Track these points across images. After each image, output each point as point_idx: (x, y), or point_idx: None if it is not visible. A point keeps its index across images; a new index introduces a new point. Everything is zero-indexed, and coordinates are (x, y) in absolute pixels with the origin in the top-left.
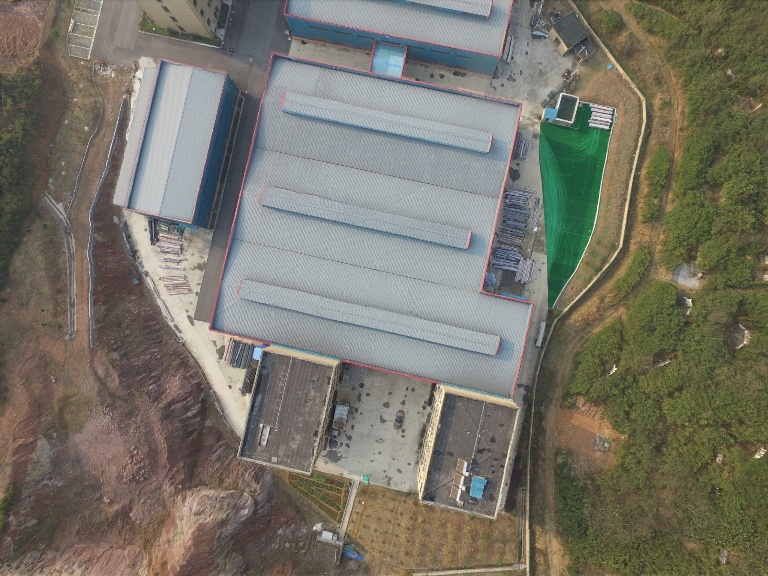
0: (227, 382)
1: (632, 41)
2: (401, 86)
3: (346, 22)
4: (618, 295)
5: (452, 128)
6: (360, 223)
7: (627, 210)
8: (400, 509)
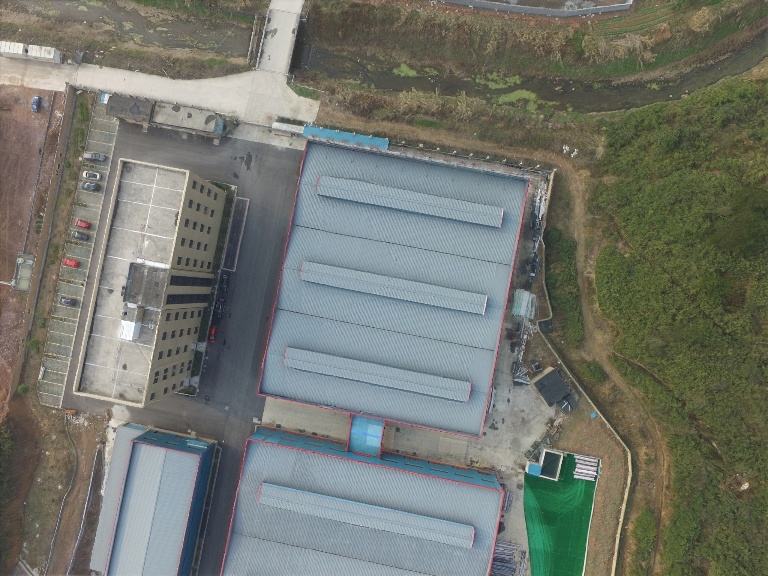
0: None
1: (615, 394)
2: (380, 470)
3: (322, 398)
4: None
5: (433, 524)
6: None
7: (615, 567)
8: None
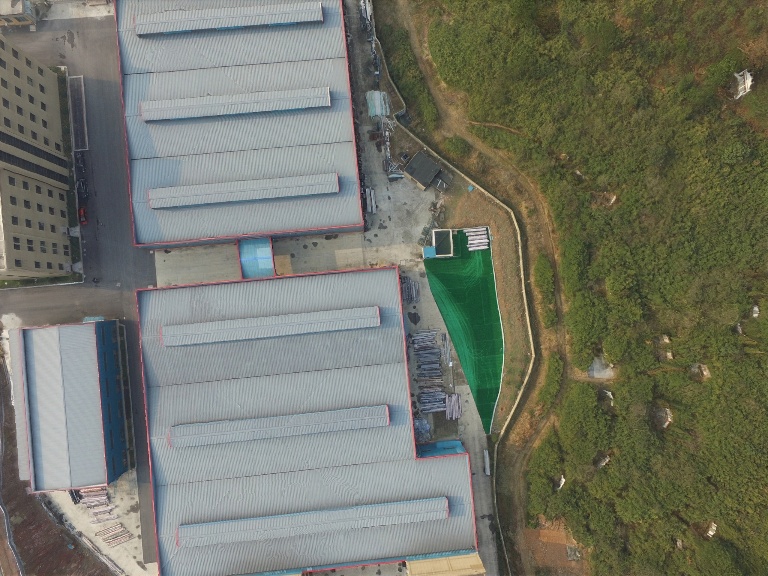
0: None
1: (483, 160)
2: (276, 282)
3: (201, 233)
4: (545, 406)
5: (338, 313)
6: (278, 434)
7: (528, 320)
8: None
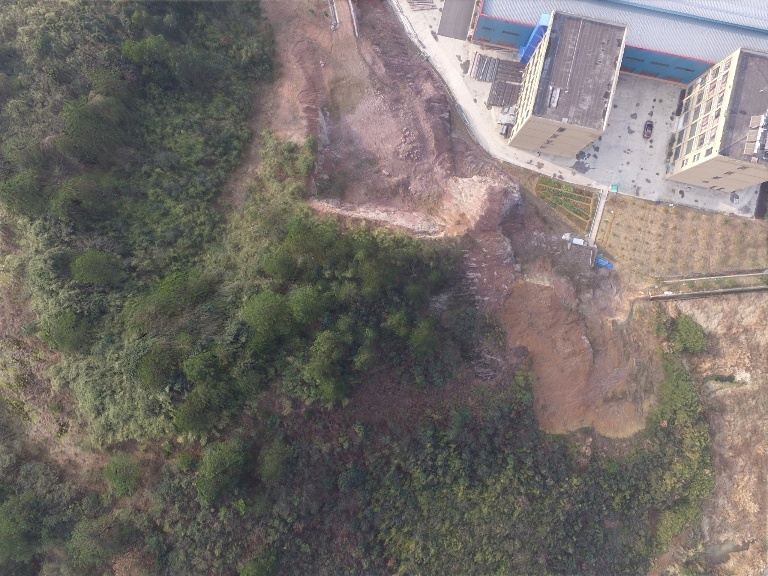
0: (472, 96)
1: None
2: None
3: None
4: None
5: None
6: None
7: None
8: (650, 217)
